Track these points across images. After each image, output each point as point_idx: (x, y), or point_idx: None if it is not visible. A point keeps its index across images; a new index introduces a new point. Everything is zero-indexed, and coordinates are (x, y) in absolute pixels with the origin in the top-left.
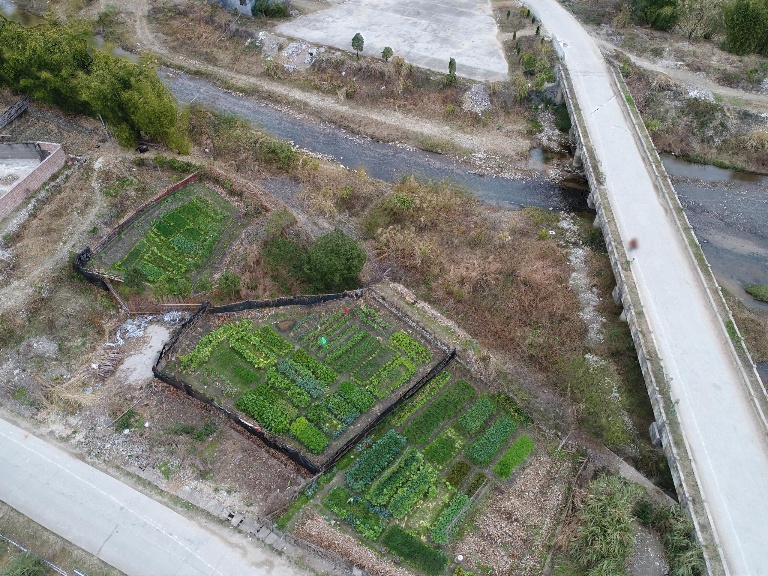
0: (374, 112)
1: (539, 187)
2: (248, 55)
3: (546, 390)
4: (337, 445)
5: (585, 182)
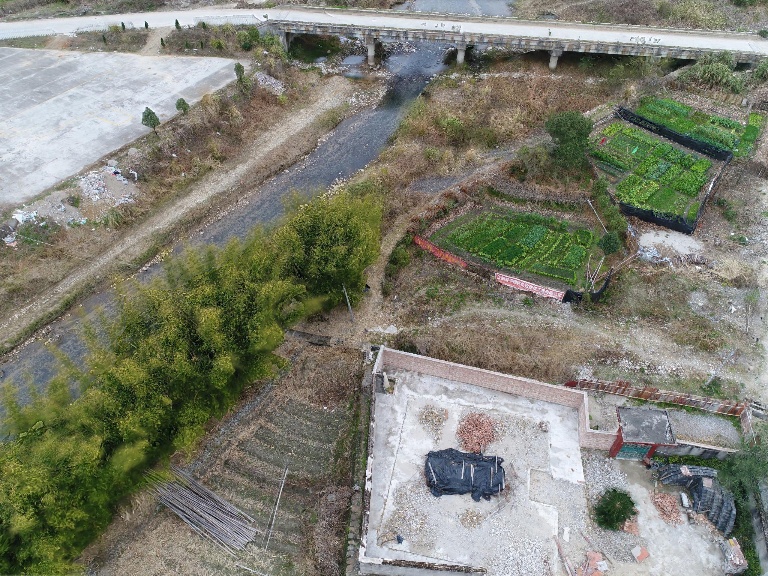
0: (257, 148)
1: (398, 83)
2: (55, 242)
3: (641, 82)
4: None
5: (393, 65)
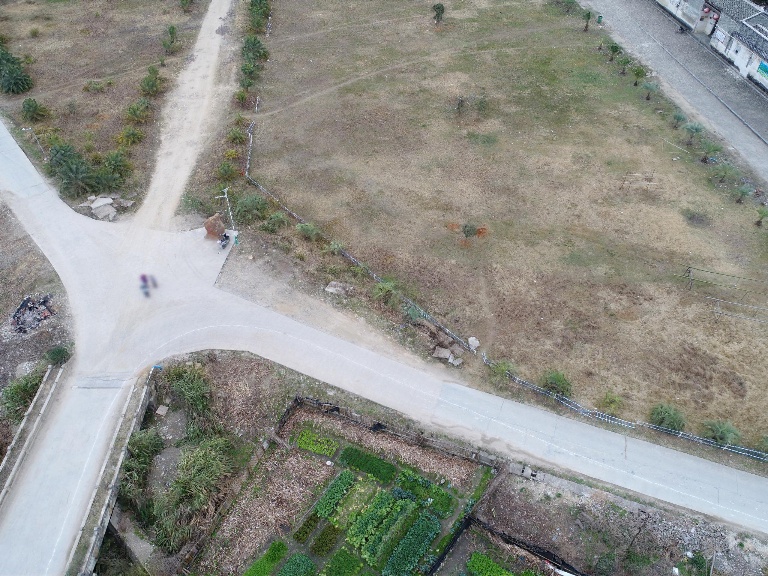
0: None
1: None
2: None
3: None
4: (457, 566)
5: None
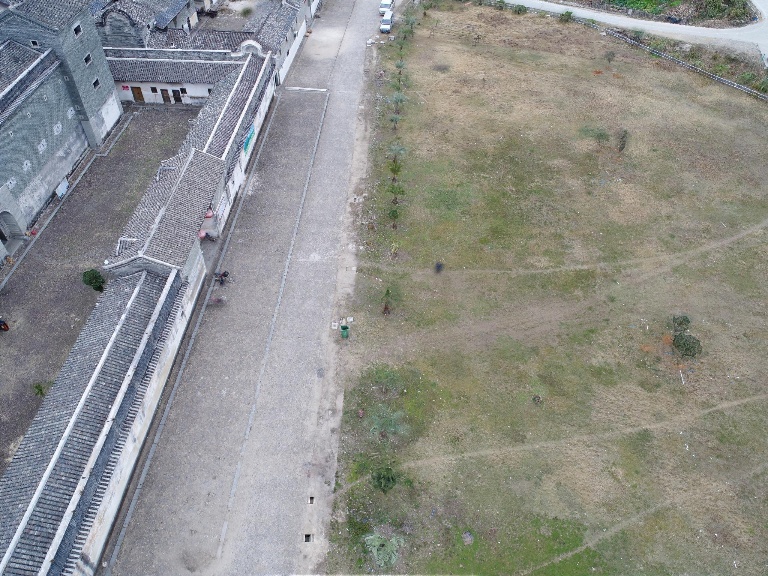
0: None
1: None
2: None
3: None
4: None
5: None
